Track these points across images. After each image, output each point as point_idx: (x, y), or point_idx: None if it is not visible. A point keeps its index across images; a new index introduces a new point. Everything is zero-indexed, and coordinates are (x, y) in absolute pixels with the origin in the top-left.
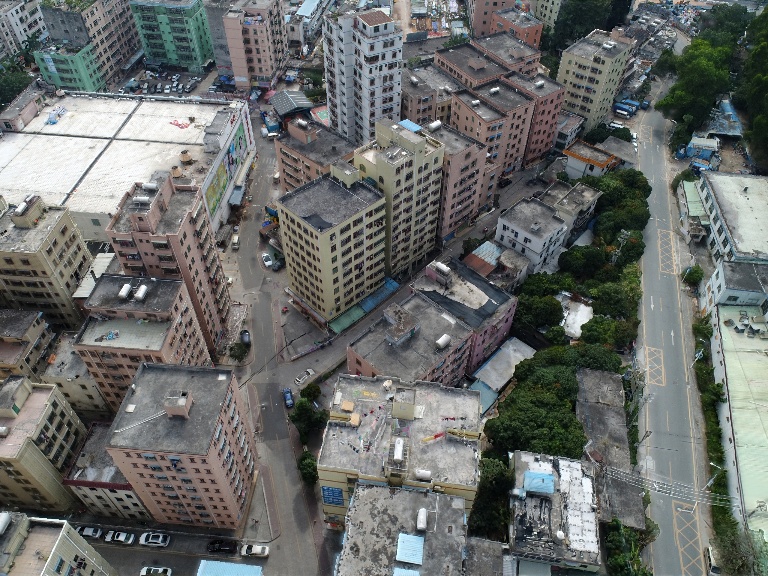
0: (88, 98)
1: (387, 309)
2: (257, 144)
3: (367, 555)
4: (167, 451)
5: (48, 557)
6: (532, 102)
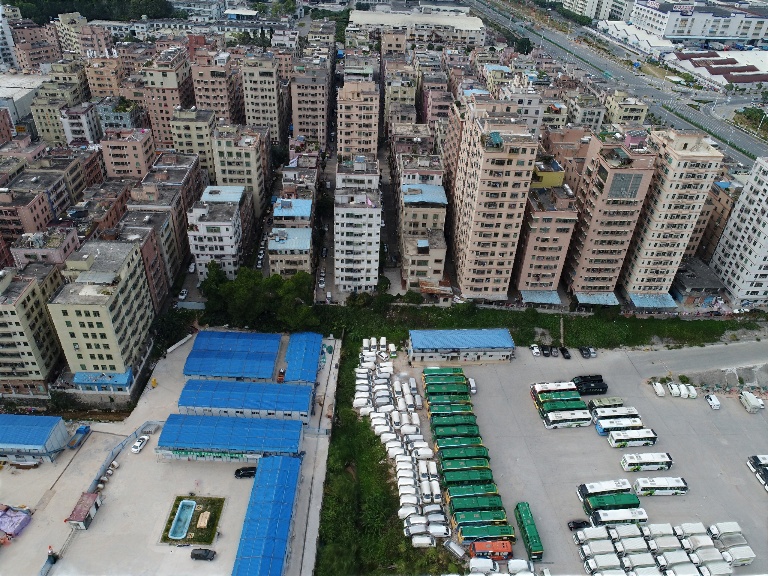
0: None
1: (135, 45)
2: None
3: None
4: None
5: None
6: None
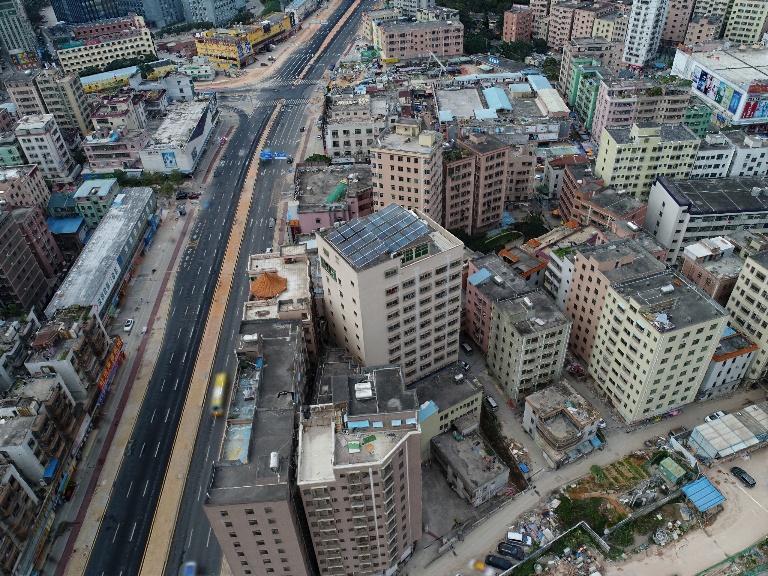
0: None
1: None
2: None
3: None
4: None
5: None
6: None
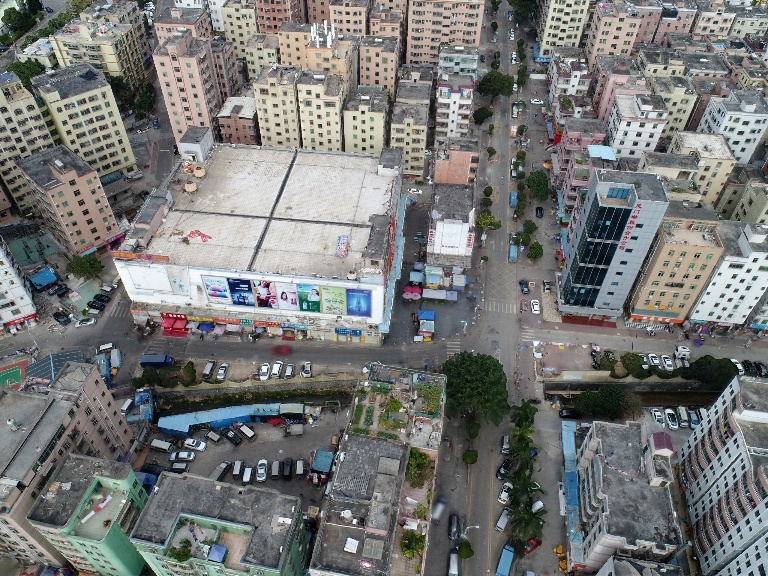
0: (317, 275)
1: None
2: (132, 341)
3: (122, 7)
4: (182, 8)
5: (225, 5)
6: None
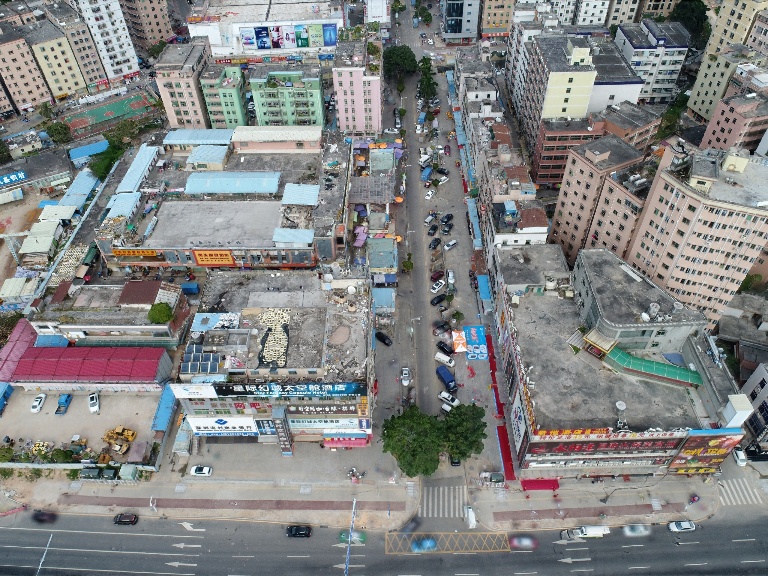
0: None
1: None
2: None
3: None
4: None
5: None
6: None
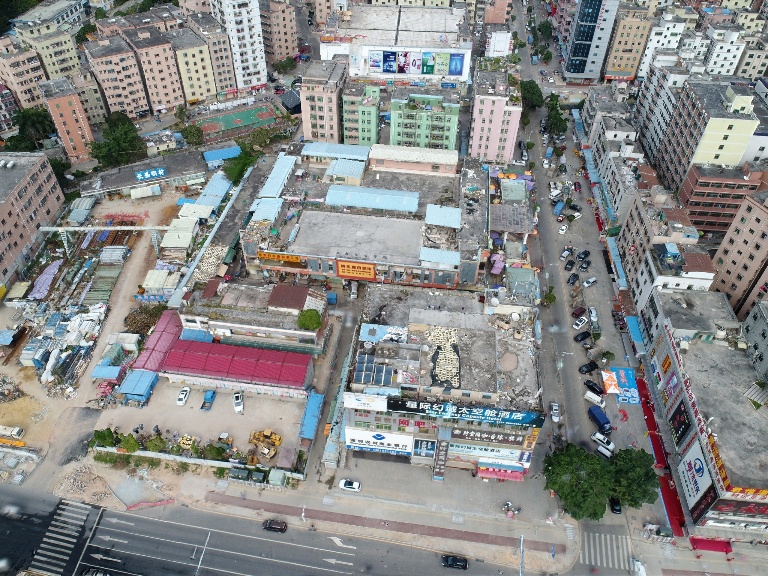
0: None
1: None
2: None
3: None
4: None
5: None
6: (127, 17)
